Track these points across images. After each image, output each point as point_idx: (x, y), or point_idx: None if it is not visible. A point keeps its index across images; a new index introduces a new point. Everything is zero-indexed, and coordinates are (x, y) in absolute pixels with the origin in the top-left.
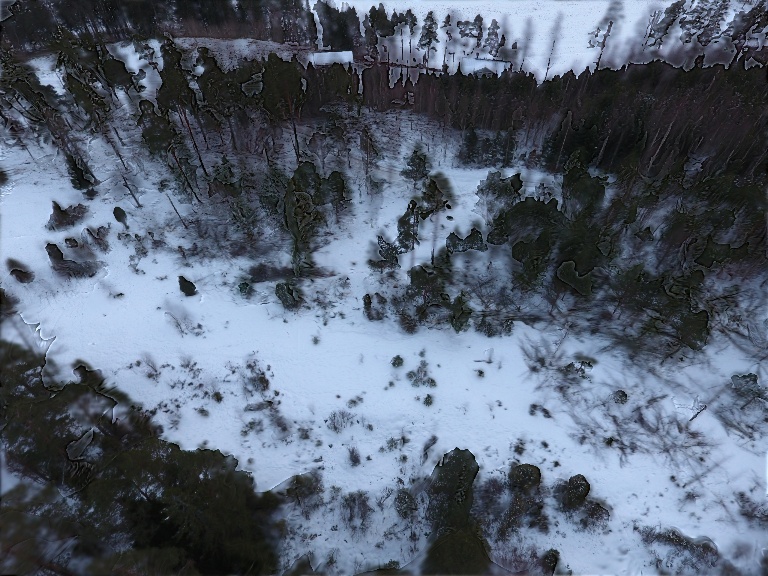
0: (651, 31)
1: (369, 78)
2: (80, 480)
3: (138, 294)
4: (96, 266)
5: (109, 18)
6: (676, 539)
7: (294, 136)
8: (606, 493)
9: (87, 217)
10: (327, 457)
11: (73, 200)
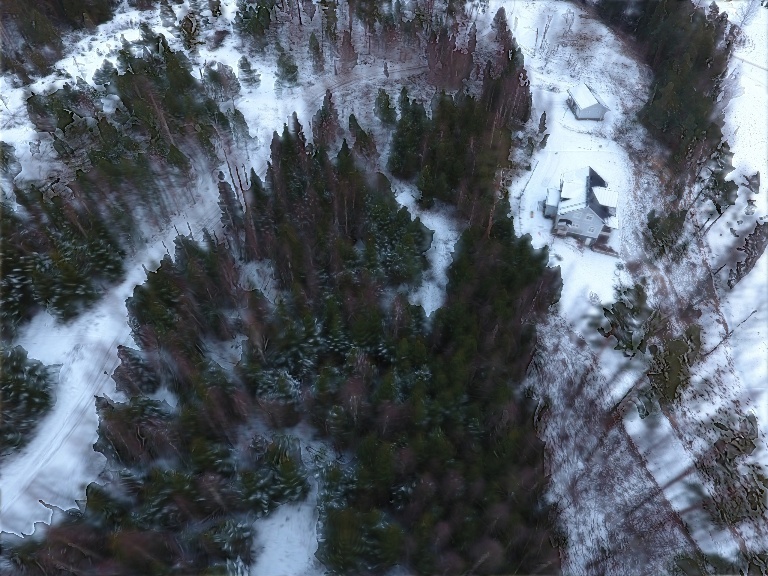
0: (650, 332)
1: None
2: None
3: (225, 8)
4: (253, 2)
5: None
6: None
7: (404, 67)
8: None
9: (298, 1)
10: (101, 36)
11: None
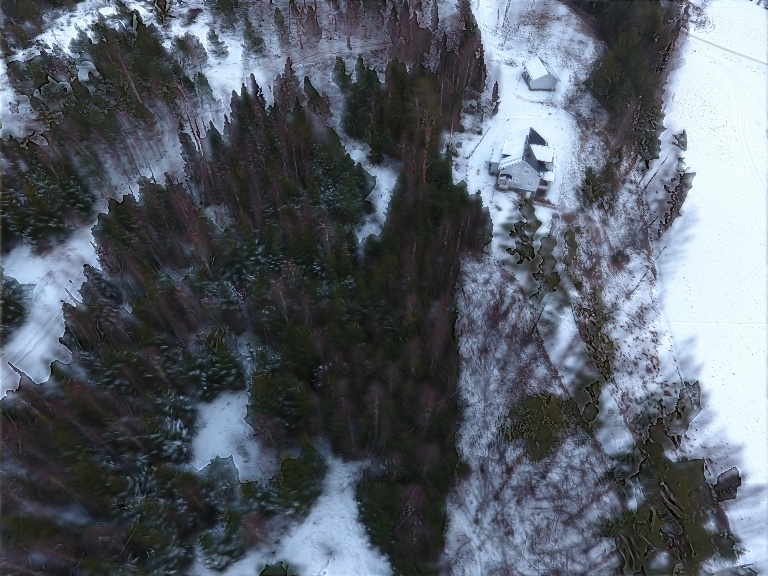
0: None
1: None
2: None
3: None
4: None
5: None
6: None
7: (369, 43)
8: (0, 61)
9: None
10: (79, 13)
11: None
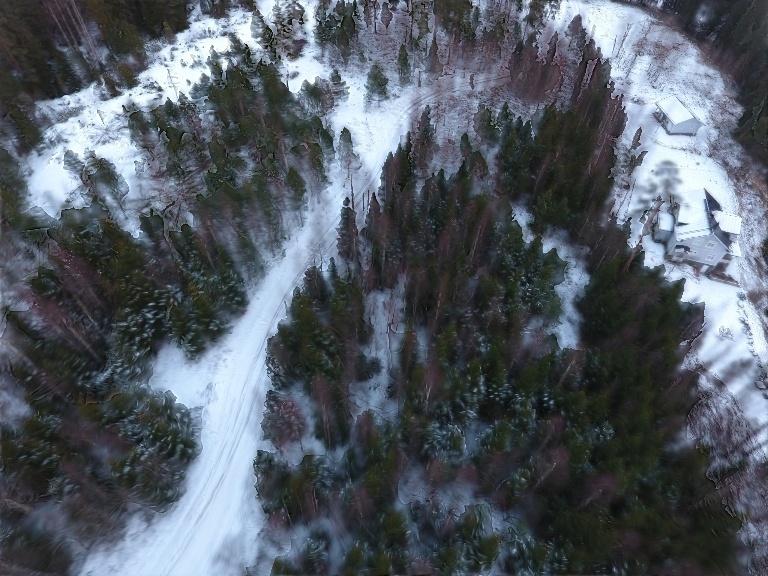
0: None
1: (580, 100)
2: (203, 4)
3: None
4: None
5: (682, 3)
6: (72, 110)
7: (484, 78)
8: None
9: None
10: None
11: (388, 6)
